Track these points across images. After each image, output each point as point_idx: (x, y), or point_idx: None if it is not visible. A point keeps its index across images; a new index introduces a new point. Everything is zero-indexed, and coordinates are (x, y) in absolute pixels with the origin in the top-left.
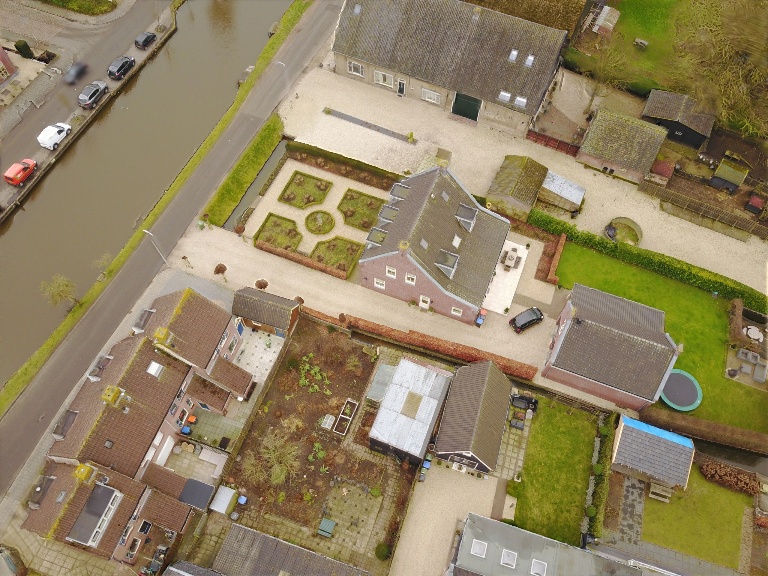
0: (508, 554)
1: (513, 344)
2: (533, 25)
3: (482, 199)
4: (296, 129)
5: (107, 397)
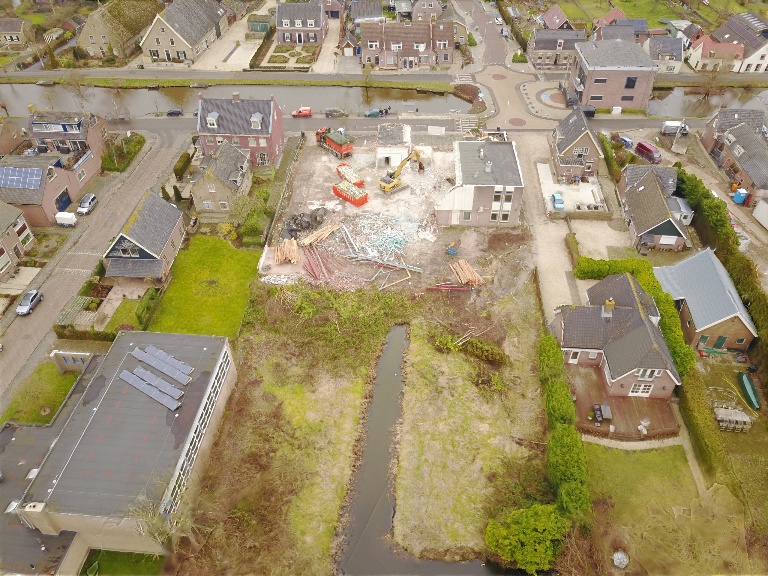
0: (403, 6)
1: (332, 24)
2: None
3: None
4: (238, 68)
5: None
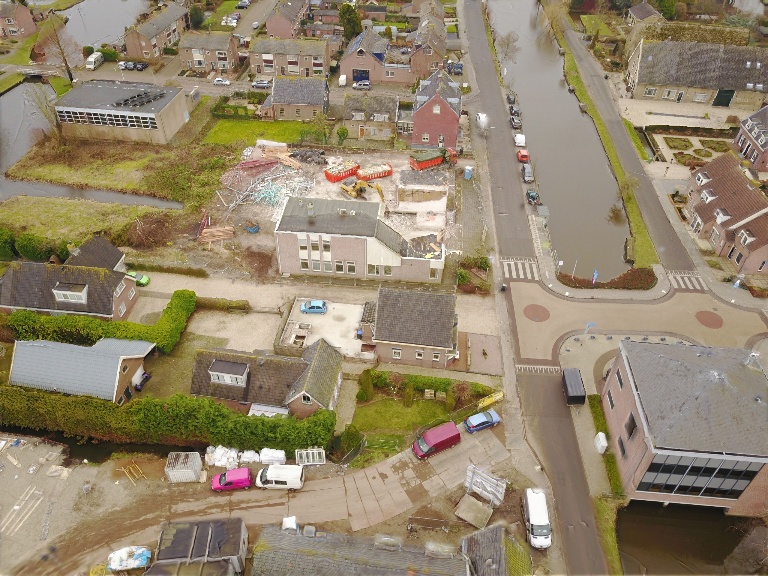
0: None
1: None
2: (755, 48)
3: None
4: (639, 123)
5: (757, 182)
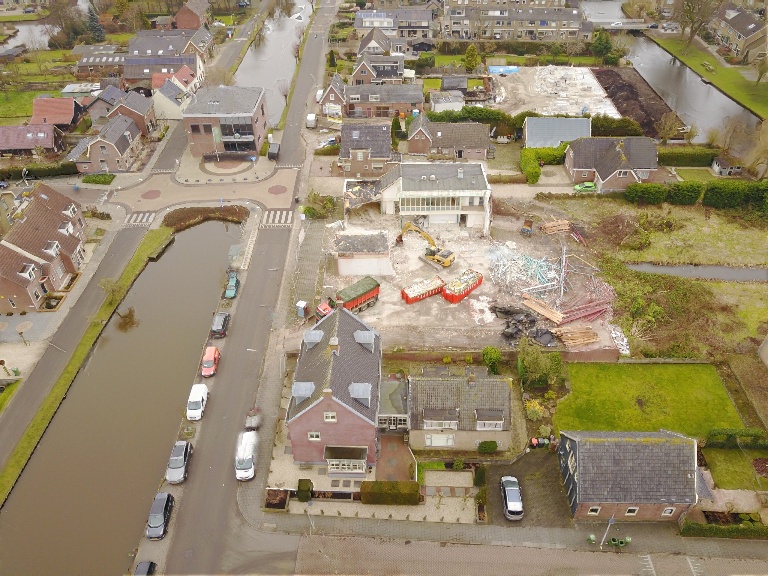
0: None
1: None
2: None
3: None
4: None
5: None
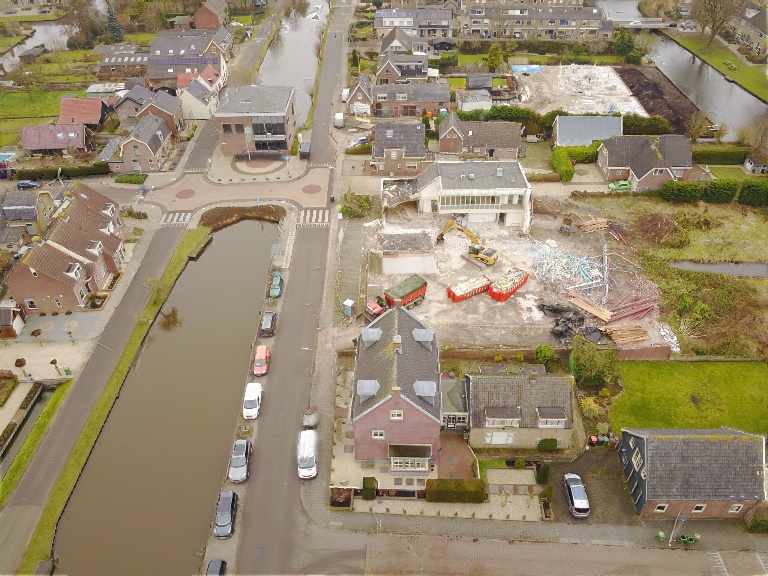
0: None
1: None
2: None
3: None
4: None
5: None
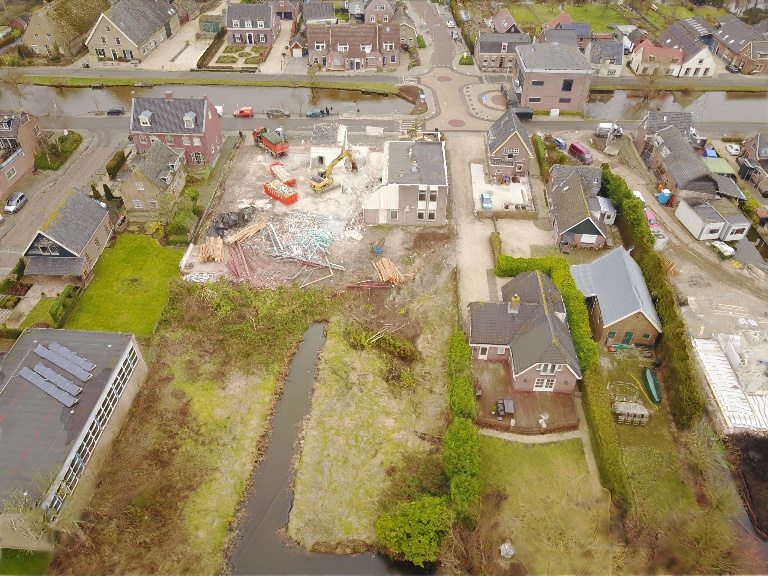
0: None
1: (285, 25)
2: None
3: (223, 27)
4: (185, 68)
5: None
